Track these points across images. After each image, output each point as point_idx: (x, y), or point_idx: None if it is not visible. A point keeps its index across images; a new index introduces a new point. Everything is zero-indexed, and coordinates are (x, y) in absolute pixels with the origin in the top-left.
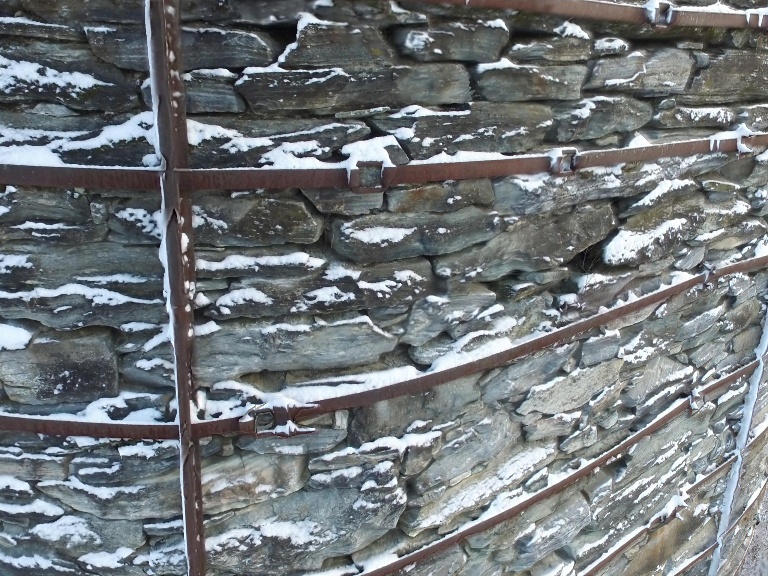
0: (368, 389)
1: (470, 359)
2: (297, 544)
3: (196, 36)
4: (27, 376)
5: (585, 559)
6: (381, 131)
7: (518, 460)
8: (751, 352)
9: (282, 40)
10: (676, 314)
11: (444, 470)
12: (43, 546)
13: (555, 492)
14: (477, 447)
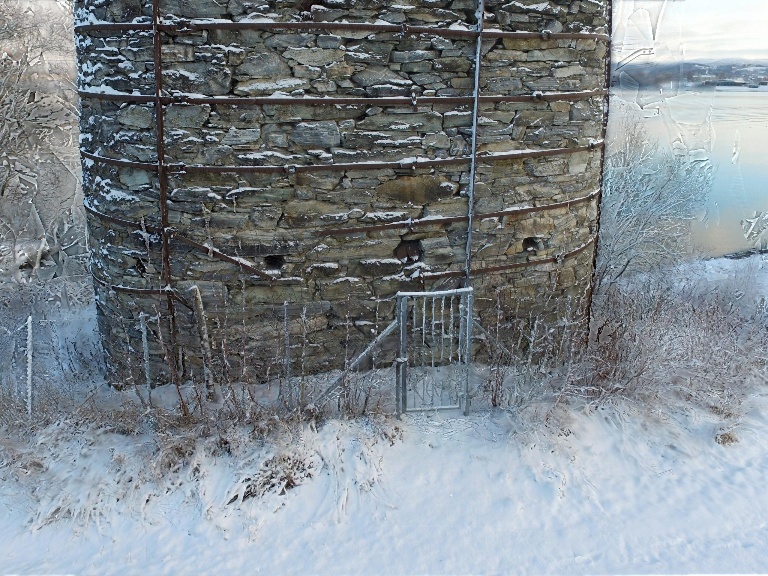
0: (213, 23)
1: (254, 22)
2: (191, 80)
3: None
4: (120, 11)
5: (340, 158)
6: None
7: (287, 80)
8: (470, 92)
9: None
10: (387, 44)
11: (248, 69)
12: (121, 74)
13: (311, 105)
14: (263, 64)
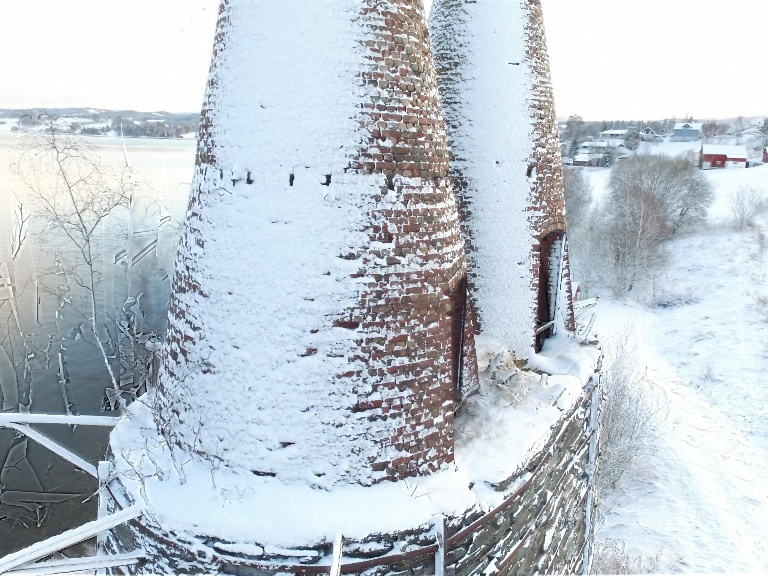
0: None
1: None
2: None
3: (446, 557)
4: None
5: None
6: (491, 557)
7: None
8: (583, 537)
9: (468, 545)
10: None
11: None
12: None
13: None
14: None
